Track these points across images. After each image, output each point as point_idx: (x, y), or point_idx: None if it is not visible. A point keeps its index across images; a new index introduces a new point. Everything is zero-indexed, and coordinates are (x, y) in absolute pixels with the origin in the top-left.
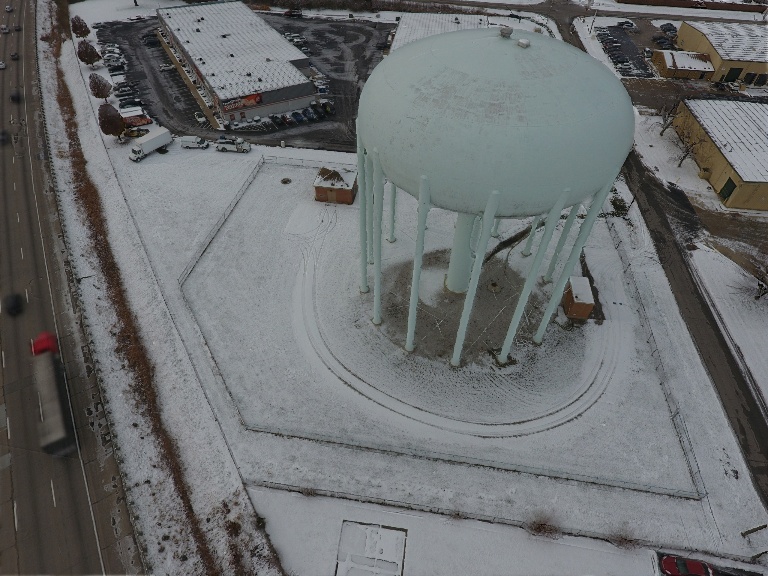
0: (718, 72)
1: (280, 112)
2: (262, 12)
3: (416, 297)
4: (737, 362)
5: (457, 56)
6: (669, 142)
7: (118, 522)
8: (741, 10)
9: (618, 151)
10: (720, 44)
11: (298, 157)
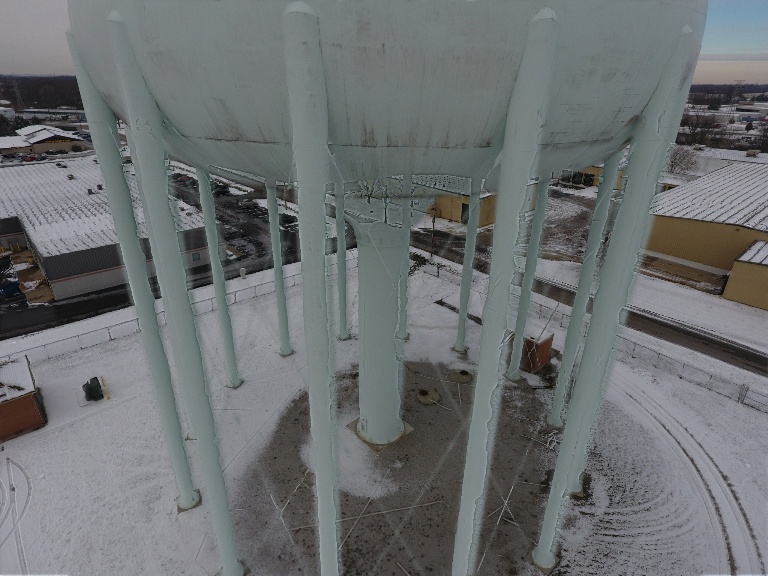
0: None
1: None
2: None
3: None
4: (663, 321)
5: None
6: (381, 205)
7: None
8: None
9: None
10: None
11: None
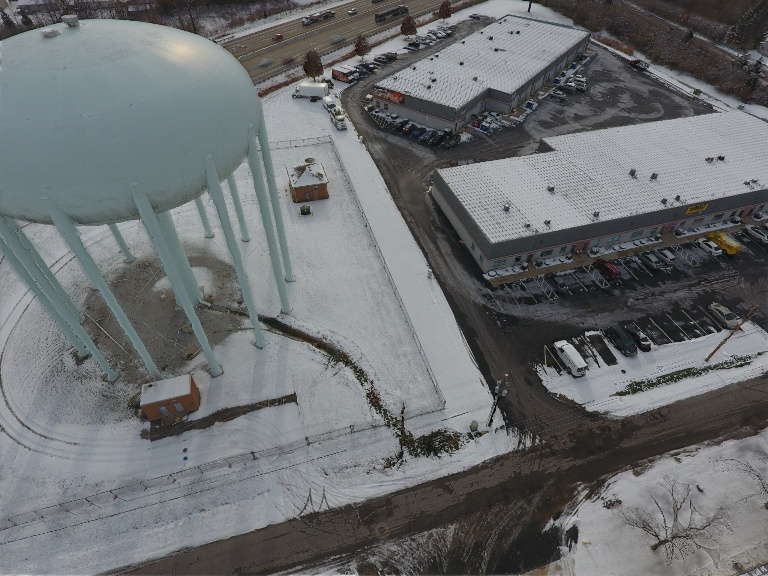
0: None
1: (418, 122)
2: (615, 53)
3: None
4: None
5: None
6: (749, 524)
7: None
8: None
9: None
10: None
11: (350, 154)
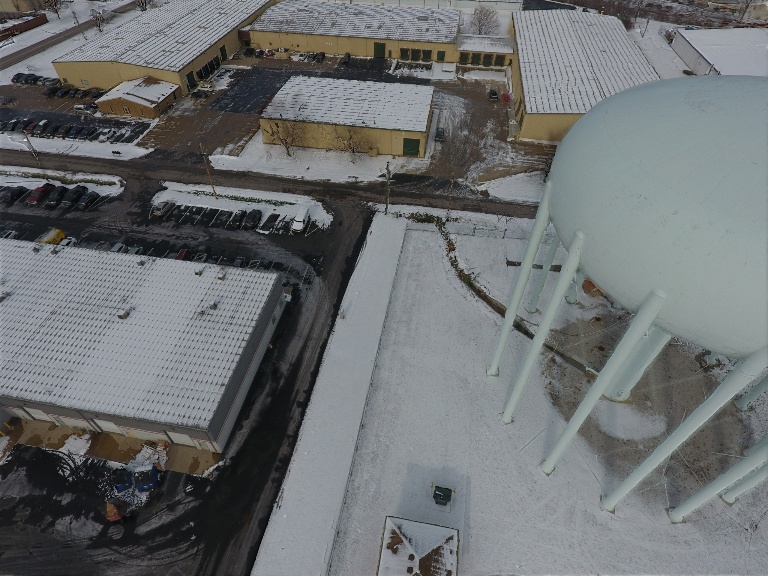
0: (183, 85)
1: None
2: None
3: None
4: None
5: None
6: (305, 155)
7: None
8: (22, 31)
9: None
10: (145, 62)
11: None
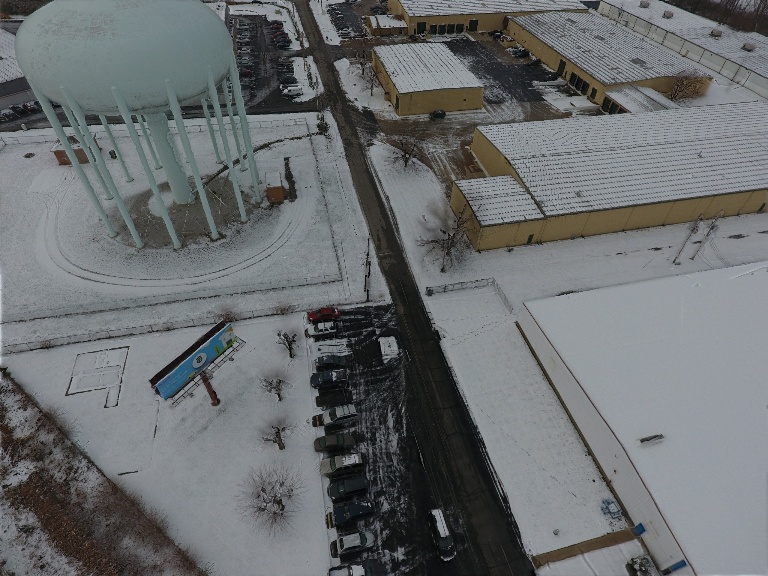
0: (410, 27)
1: (21, 103)
2: (1, 21)
3: (117, 195)
4: (384, 204)
5: (71, 2)
6: None
7: None
8: None
9: (204, 54)
10: (408, 6)
11: None
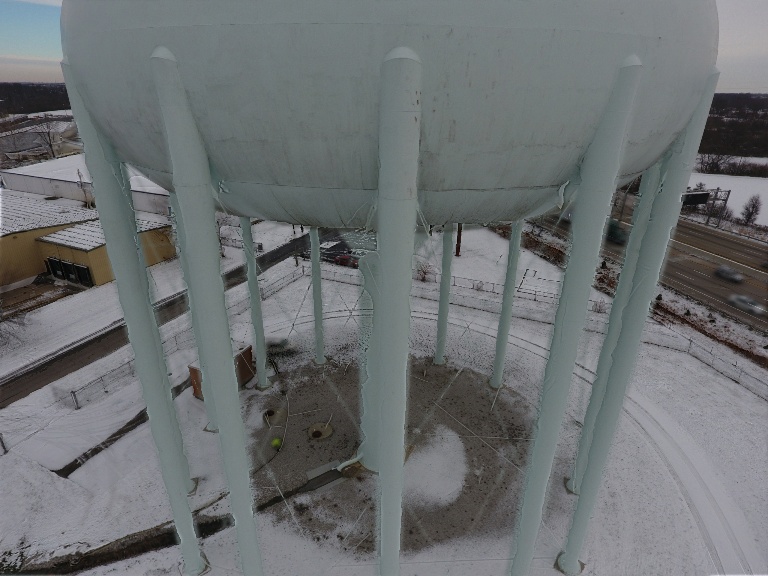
0: None
1: None
2: None
3: None
4: None
5: None
6: None
7: (766, 330)
8: None
9: None
10: None
11: None
